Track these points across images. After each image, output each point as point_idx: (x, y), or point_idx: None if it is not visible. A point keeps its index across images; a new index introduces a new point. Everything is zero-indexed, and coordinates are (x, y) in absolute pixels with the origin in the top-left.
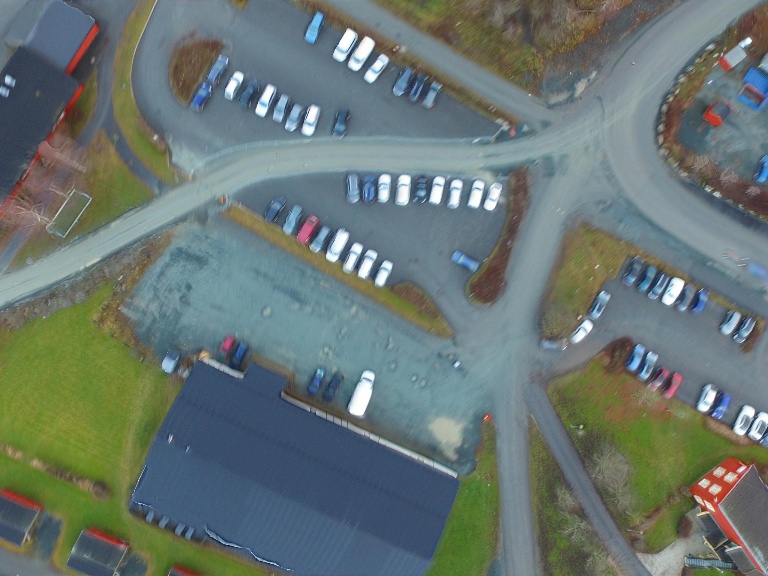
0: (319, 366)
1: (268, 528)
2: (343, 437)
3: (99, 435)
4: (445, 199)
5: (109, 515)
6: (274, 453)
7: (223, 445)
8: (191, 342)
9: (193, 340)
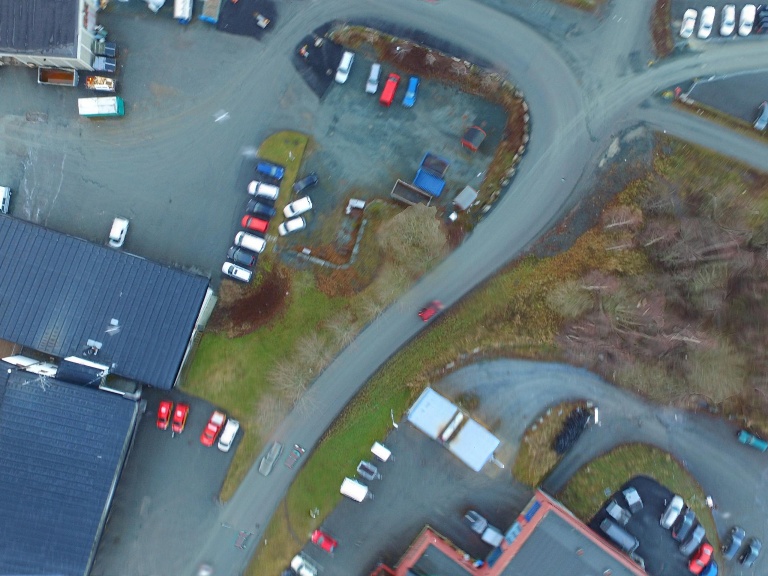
0: None
1: None
2: None
3: None
4: (737, 14)
5: None
6: None
7: None
8: None
9: None
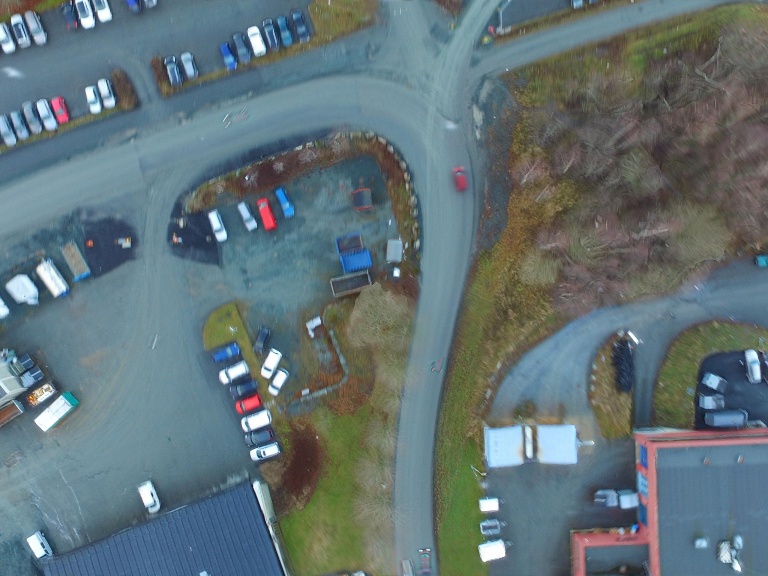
0: None
1: None
2: None
3: None
4: None
5: None
6: None
7: None
8: None
9: None
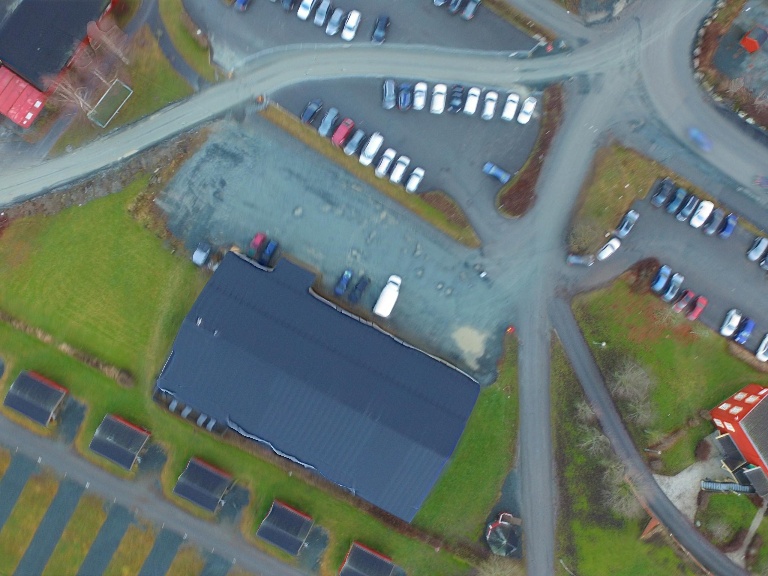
0: (347, 268)
1: (290, 417)
2: (368, 334)
3: (127, 324)
4: (479, 110)
5: (133, 403)
6: (300, 344)
7: (250, 333)
8: (222, 237)
9: (224, 235)
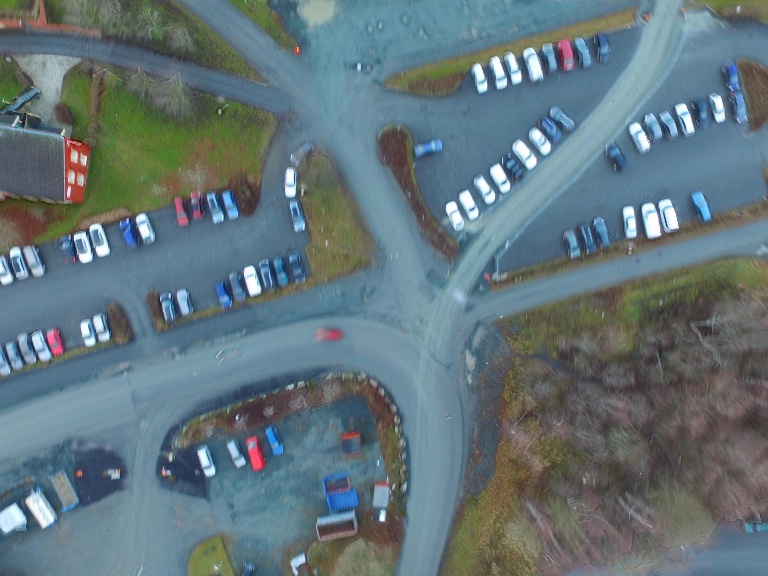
0: None
1: None
2: None
3: None
4: (489, 179)
5: None
6: None
7: None
8: None
9: None
